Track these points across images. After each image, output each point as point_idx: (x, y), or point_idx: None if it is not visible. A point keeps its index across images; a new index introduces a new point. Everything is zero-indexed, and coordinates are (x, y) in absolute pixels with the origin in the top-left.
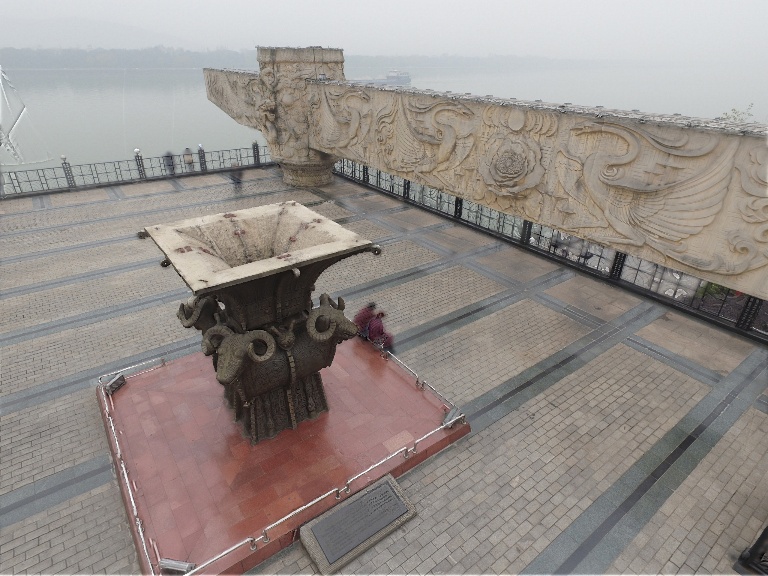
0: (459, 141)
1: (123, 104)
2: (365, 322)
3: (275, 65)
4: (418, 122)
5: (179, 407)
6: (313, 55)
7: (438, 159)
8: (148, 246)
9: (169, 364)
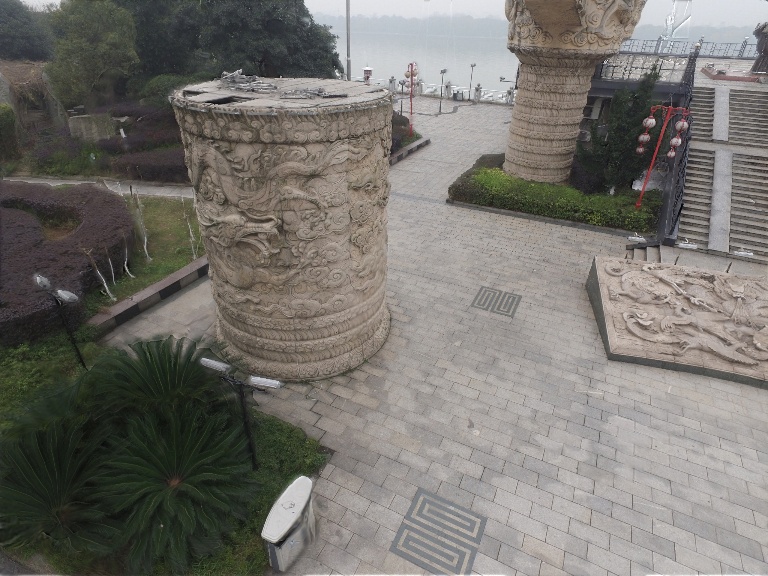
0: None
1: (752, 18)
2: None
3: None
4: None
5: None
6: None
7: None
8: (732, 65)
9: None
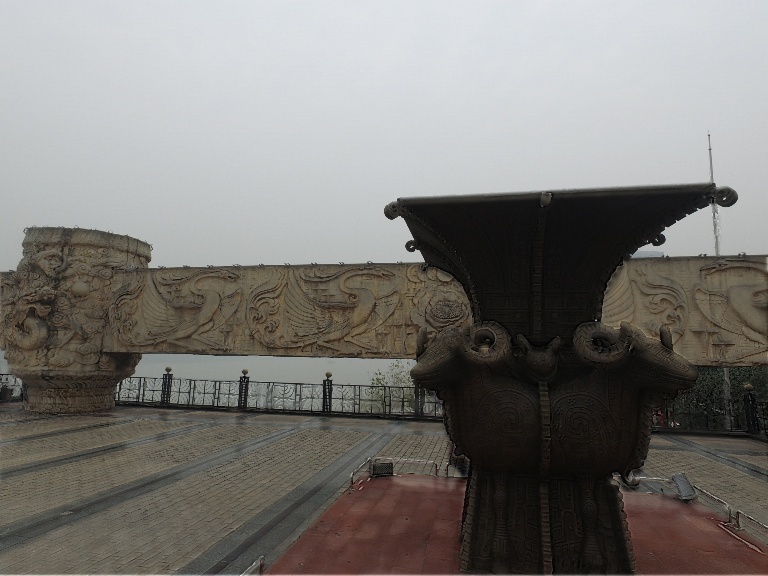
0: (380, 301)
1: None
2: None
3: (66, 248)
4: (320, 291)
5: None
6: (127, 244)
7: (354, 322)
8: None
9: None
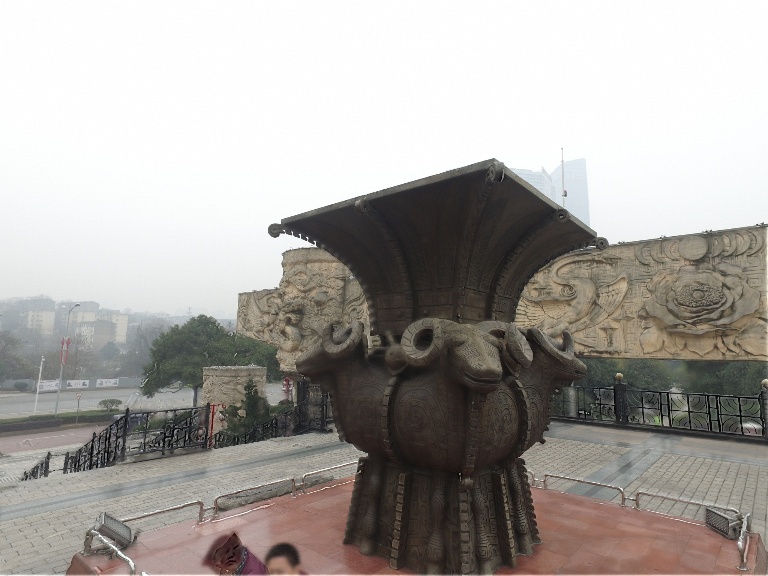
0: None
1: None
2: None
3: None
4: None
5: (582, 524)
6: None
7: None
8: None
9: (741, 571)
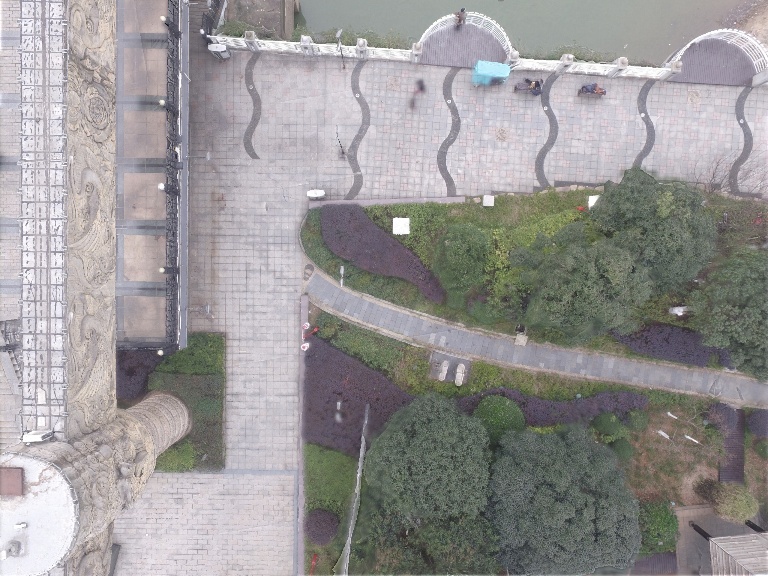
0: None
1: None
2: (4, 135)
3: None
4: None
5: None
6: None
7: None
8: None
9: None
